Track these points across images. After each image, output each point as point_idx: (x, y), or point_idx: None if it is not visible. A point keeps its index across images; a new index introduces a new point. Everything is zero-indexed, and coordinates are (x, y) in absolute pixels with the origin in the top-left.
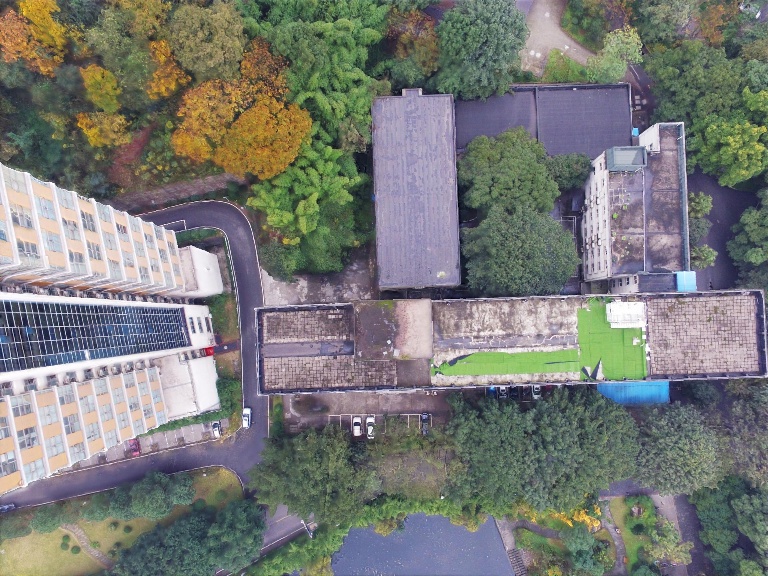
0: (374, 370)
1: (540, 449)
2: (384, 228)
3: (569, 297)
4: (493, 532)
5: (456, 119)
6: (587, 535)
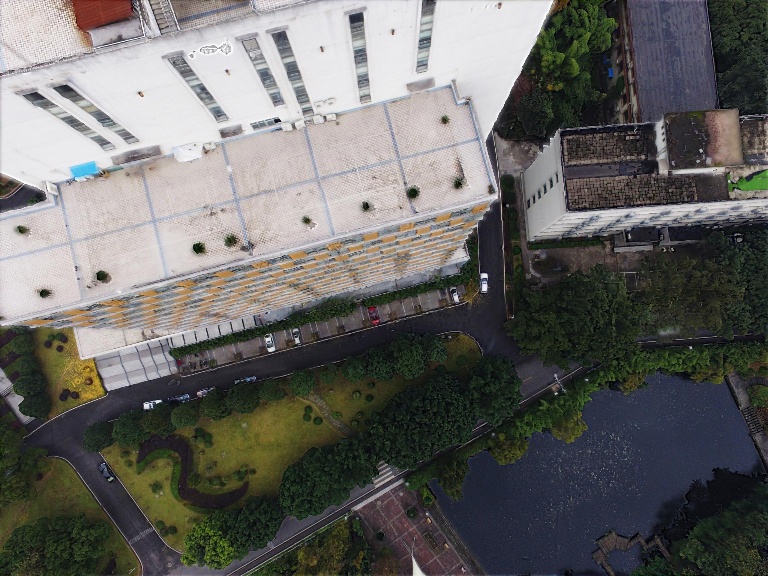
0: (674, 187)
1: None
2: (642, 73)
3: None
4: (726, 391)
5: None
6: None
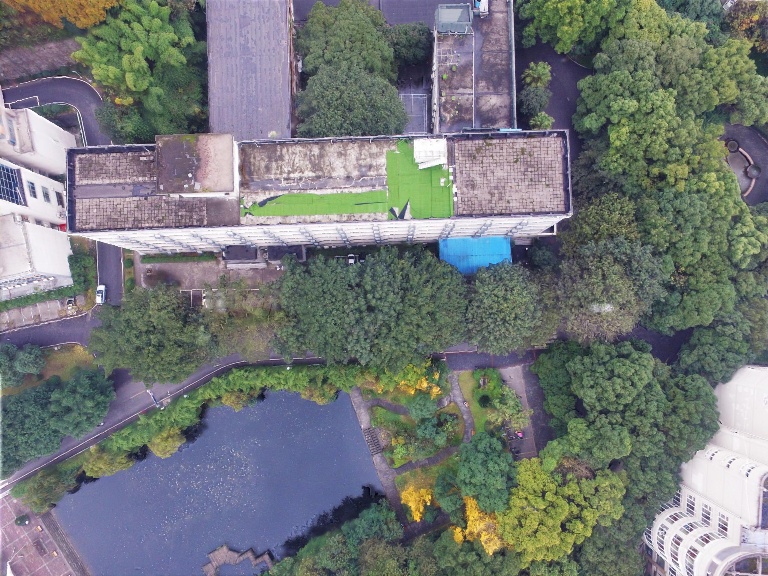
0: (184, 211)
1: (359, 298)
2: (216, 89)
3: (376, 138)
4: (349, 412)
5: None
6: (428, 402)
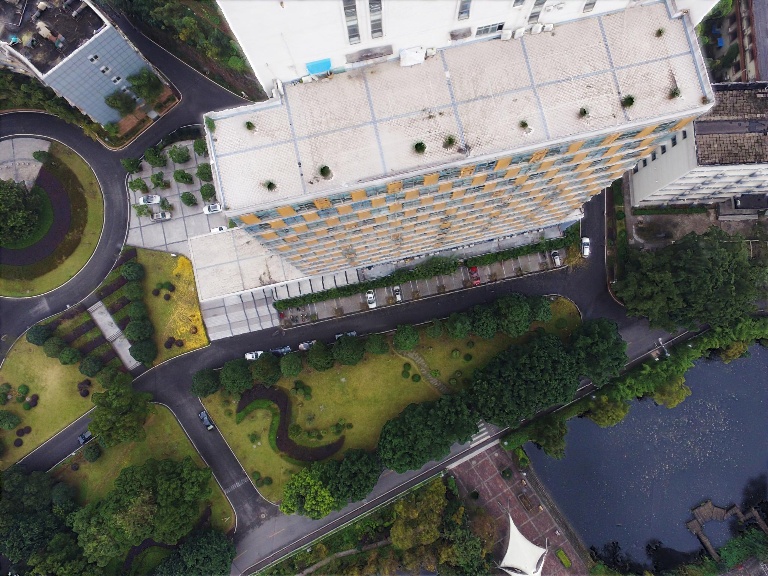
0: None
1: None
2: (761, 38)
3: None
4: None
5: None
6: None
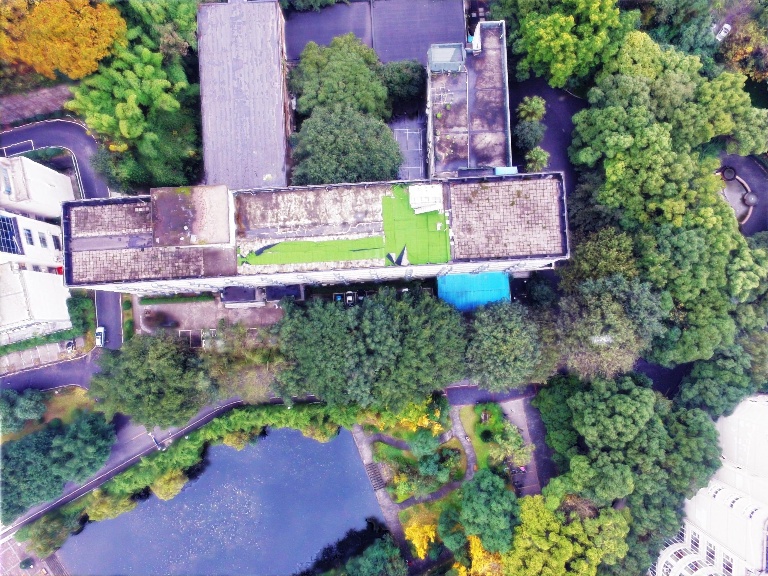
0: (181, 261)
1: (358, 342)
2: (211, 133)
3: (372, 184)
4: (351, 447)
5: (292, 30)
6: (430, 439)
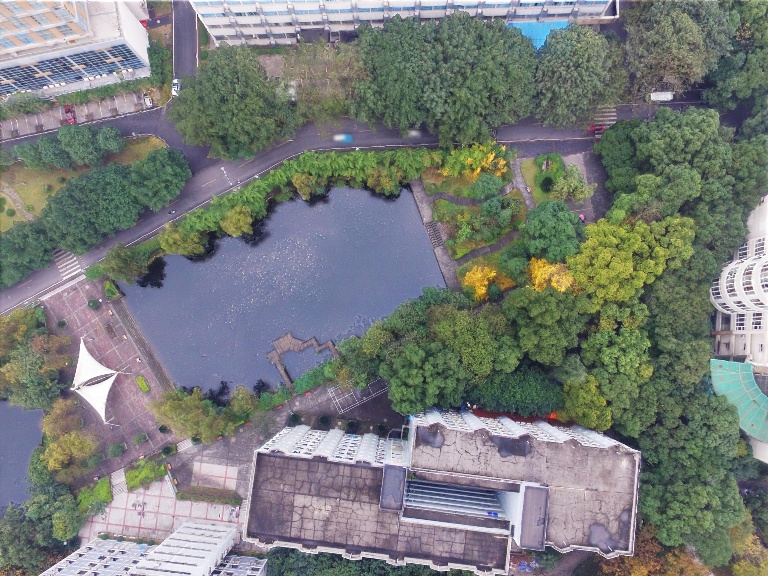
0: None
1: (436, 45)
2: None
3: None
4: (412, 207)
5: None
6: (494, 176)
